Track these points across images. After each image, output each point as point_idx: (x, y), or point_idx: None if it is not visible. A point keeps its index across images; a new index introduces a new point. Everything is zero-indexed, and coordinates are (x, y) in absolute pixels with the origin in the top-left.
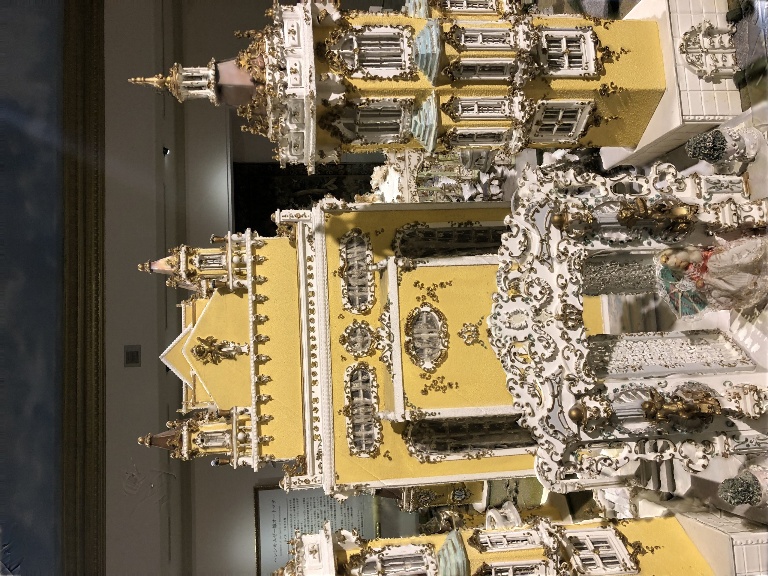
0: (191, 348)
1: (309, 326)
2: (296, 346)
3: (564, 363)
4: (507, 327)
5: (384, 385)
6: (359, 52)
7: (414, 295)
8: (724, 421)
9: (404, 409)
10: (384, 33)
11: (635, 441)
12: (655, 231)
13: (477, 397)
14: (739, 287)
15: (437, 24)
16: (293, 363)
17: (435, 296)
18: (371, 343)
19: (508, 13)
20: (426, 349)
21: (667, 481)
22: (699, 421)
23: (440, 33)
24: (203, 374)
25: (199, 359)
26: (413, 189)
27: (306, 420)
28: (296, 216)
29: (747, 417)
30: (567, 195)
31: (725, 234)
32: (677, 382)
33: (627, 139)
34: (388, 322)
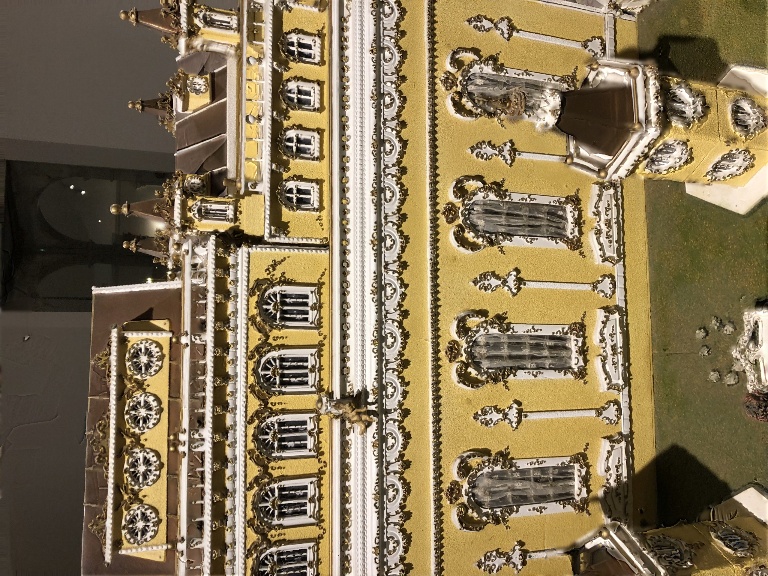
0: None
1: None
2: None
3: None
4: None
5: None
6: None
7: None
8: None
9: None
10: None
11: None
12: None
13: None
14: None
15: None
16: None
17: None
18: None
19: None
20: None
21: None
22: None
23: None
24: None
25: None
26: None
27: None
28: None
29: None
30: None
31: None
32: None
33: None
34: None
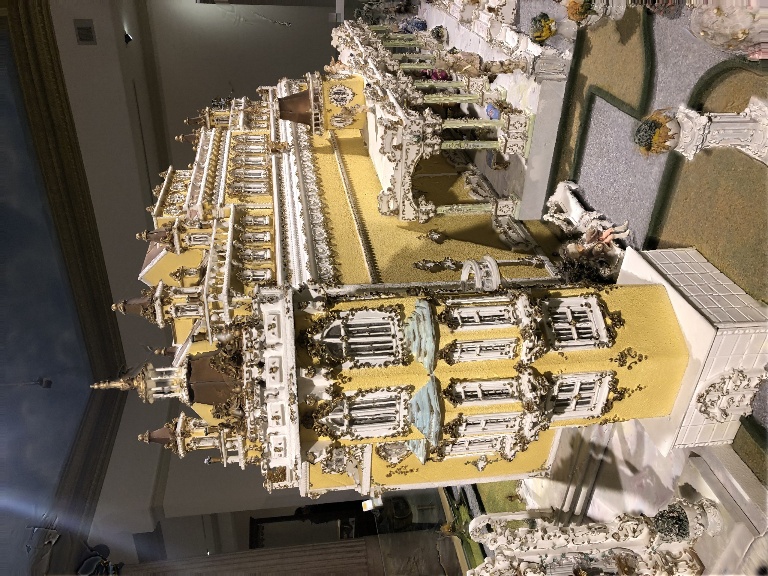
0: None
1: None
2: None
3: None
4: None
5: None
6: (350, 418)
7: None
8: None
9: (370, 487)
10: (380, 396)
11: None
12: None
13: (433, 476)
14: None
15: (438, 422)
16: None
17: None
18: None
19: (524, 365)
20: (394, 449)
21: None
22: None
23: (440, 427)
24: None
25: None
26: (407, 186)
27: None
28: None
29: None
30: (531, 547)
31: None
32: None
33: None
34: None
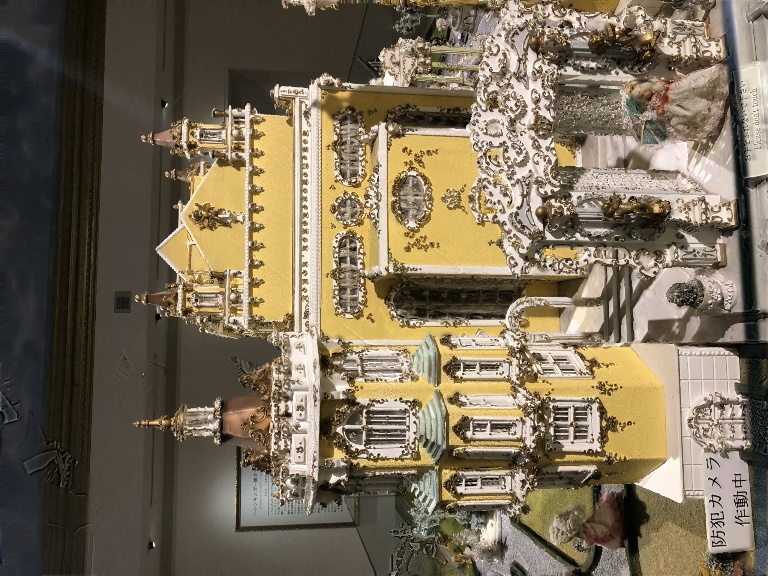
0: (189, 213)
1: (302, 195)
2: (289, 217)
3: (534, 168)
4: (484, 133)
5: (370, 253)
6: None
7: (402, 160)
8: (675, 234)
9: (388, 263)
10: None
11: (594, 246)
12: (622, 61)
13: (456, 257)
14: (694, 112)
15: None
16: (285, 233)
17: (422, 162)
18: (360, 213)
19: None
20: (411, 210)
21: (627, 332)
22: (653, 231)
23: None
24: (199, 239)
25: (196, 223)
26: None
27: (295, 281)
28: (294, 92)
29: (695, 226)
30: (545, 26)
31: (685, 68)
32: (635, 195)
33: (605, 5)
34: (377, 182)
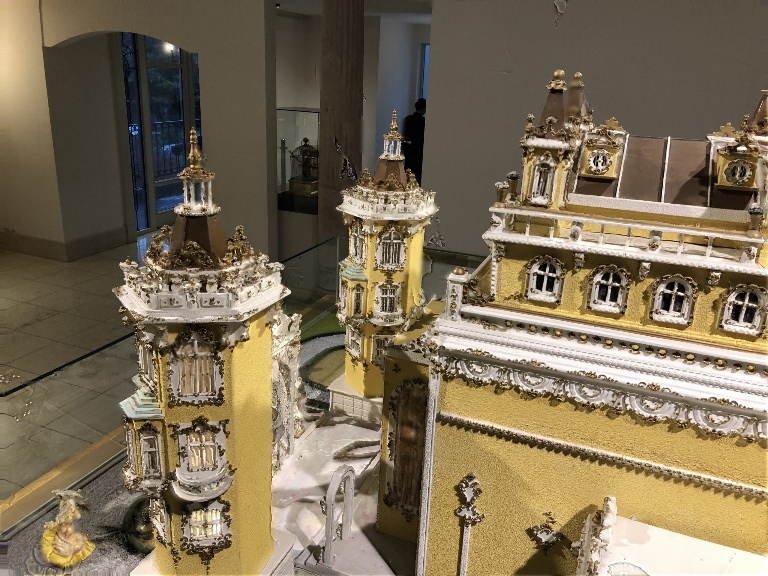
0: None
1: None
2: None
3: None
4: None
5: None
6: None
7: None
8: None
9: None
10: None
11: None
12: None
13: None
14: None
15: None
16: None
17: None
18: None
19: None
20: None
21: None
22: None
23: None
24: None
25: None
26: None
27: None
28: None
29: None
30: None
31: None
32: None
33: None
34: None
